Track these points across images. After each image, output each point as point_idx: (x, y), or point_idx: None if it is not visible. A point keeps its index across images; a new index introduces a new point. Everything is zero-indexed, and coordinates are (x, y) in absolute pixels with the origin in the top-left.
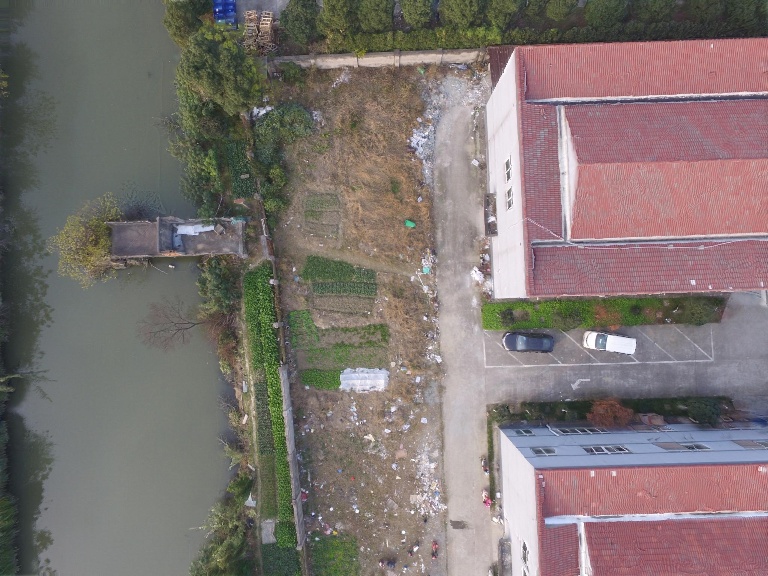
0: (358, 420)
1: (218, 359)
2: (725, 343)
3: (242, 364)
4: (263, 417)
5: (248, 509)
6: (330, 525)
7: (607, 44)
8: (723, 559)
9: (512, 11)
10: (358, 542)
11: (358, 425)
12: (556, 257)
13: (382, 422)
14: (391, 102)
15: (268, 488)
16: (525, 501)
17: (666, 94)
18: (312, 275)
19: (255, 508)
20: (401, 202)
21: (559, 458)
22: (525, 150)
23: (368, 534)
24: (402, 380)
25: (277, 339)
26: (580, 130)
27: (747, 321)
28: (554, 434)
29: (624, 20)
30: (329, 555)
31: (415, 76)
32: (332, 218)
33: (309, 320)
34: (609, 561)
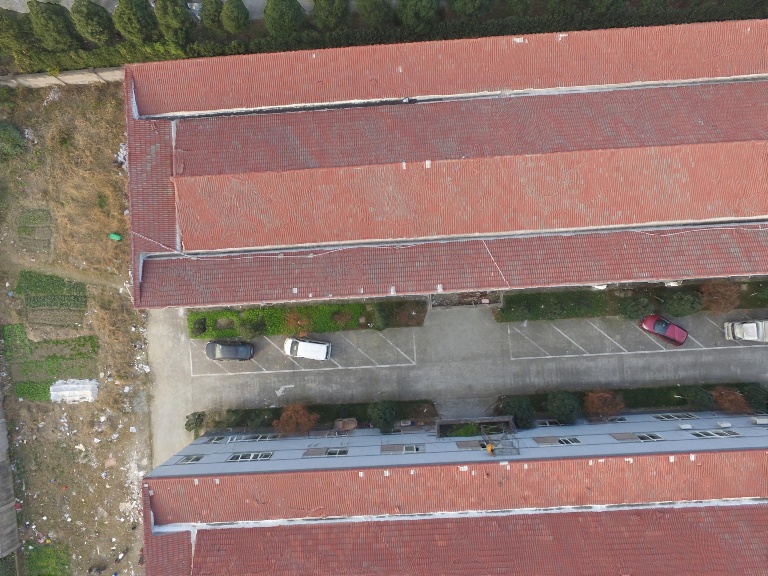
0: (69, 430)
1: None
2: (427, 347)
3: None
4: None
5: None
6: (43, 534)
7: (211, 58)
8: (326, 564)
9: (178, 26)
10: (70, 550)
11: (69, 435)
12: (174, 269)
13: (92, 432)
14: (99, 118)
15: None
16: None
17: (278, 105)
18: (24, 289)
19: None
20: (108, 216)
21: (188, 466)
22: (132, 165)
23: (80, 542)
24: (111, 390)
25: None
26: (184, 144)
27: (449, 324)
28: (226, 441)
29: (301, 30)
30: (42, 563)
31: (122, 92)
32: (44, 233)
33: (22, 333)
34: (224, 567)
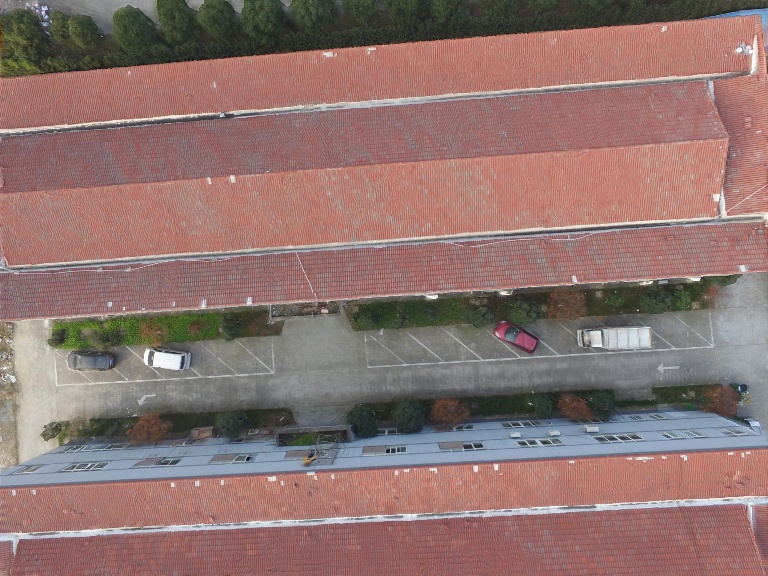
0: None
1: None
2: (285, 355)
3: None
4: None
5: None
6: None
7: (29, 76)
8: None
9: None
10: None
11: None
12: None
13: None
14: None
15: None
16: None
17: (99, 121)
18: None
19: None
20: None
21: (17, 477)
22: None
23: None
24: None
25: None
26: (3, 161)
27: (306, 333)
28: (74, 451)
29: (152, 44)
30: None
31: None
32: None
33: None
34: None
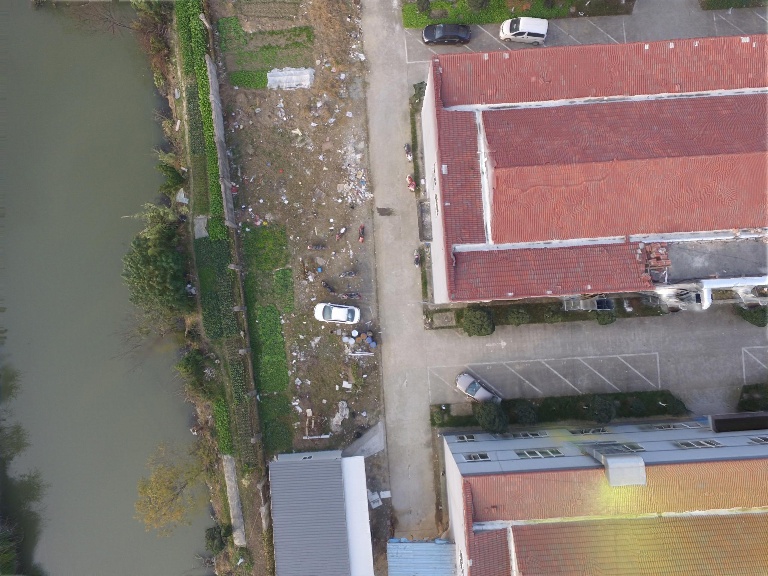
0: (285, 115)
1: (152, 75)
2: (637, 33)
3: (174, 73)
4: (194, 119)
5: (181, 205)
6: (260, 216)
7: None
8: (615, 133)
9: None
10: (287, 231)
11: (286, 121)
12: None
13: (309, 117)
14: None
15: (200, 185)
16: (431, 116)
17: None
18: None
19: (188, 205)
20: None
21: None
22: None
23: (297, 223)
24: (327, 77)
25: (207, 45)
26: None
27: (657, 12)
28: None
29: None
30: (259, 244)
31: None
32: None
33: (237, 25)
34: (508, 148)
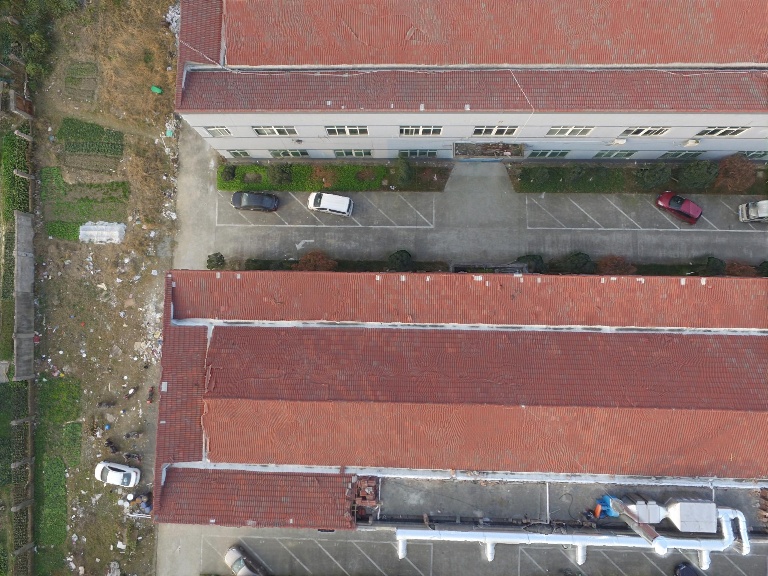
0: (93, 269)
1: None
2: (446, 211)
3: None
4: (9, 264)
5: None
6: (58, 367)
7: None
8: (337, 363)
9: None
10: (82, 384)
11: (93, 274)
12: (214, 82)
13: (115, 272)
14: None
15: (7, 331)
16: None
17: None
18: (65, 135)
19: None
20: (151, 71)
21: None
22: None
23: (92, 378)
24: (138, 234)
25: None
26: None
27: (469, 191)
28: None
29: None
30: (54, 396)
31: None
32: (89, 84)
33: (59, 176)
34: (236, 365)
